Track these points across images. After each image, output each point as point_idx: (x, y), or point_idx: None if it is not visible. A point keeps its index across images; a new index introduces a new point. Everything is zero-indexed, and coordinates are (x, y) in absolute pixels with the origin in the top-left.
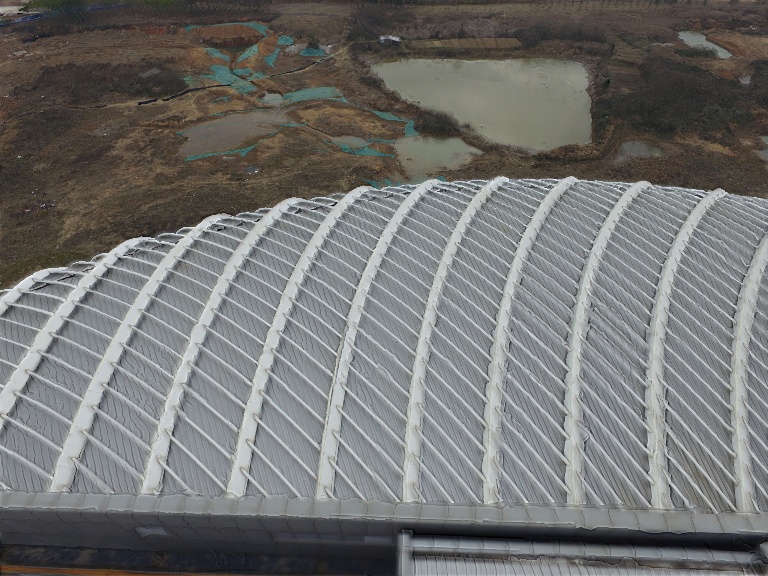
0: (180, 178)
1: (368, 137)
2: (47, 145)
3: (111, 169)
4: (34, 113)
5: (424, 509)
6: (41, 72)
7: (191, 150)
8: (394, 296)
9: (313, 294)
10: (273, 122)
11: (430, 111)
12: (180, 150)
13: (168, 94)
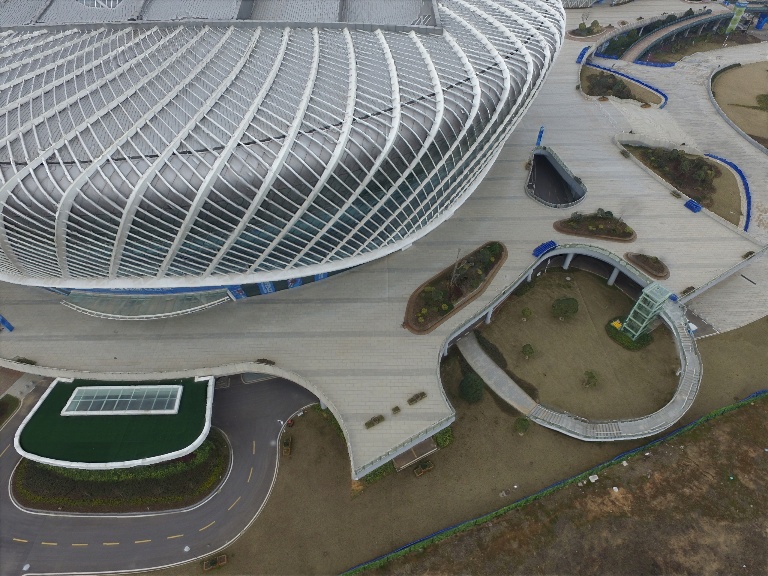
0: None
1: None
2: None
3: None
4: None
5: (227, 20)
6: None
7: None
8: (218, 70)
9: (260, 71)
10: None
11: None
12: None
13: None
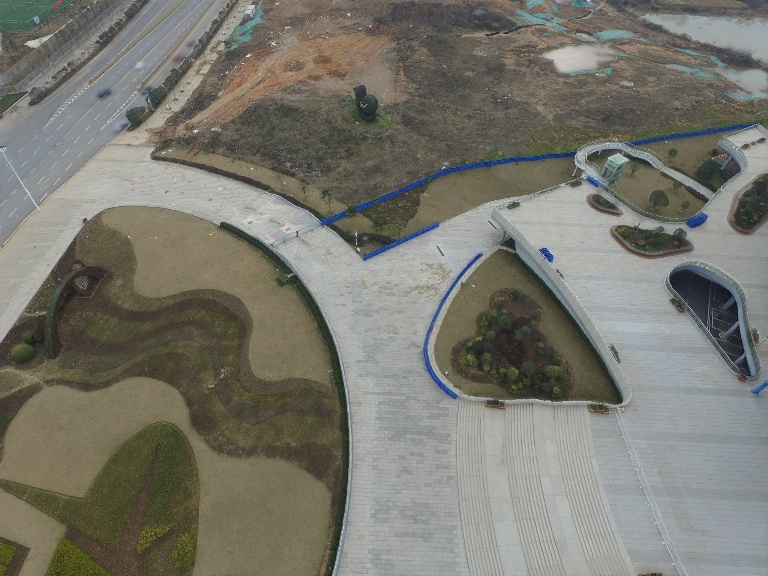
0: (584, 85)
1: (692, 65)
2: (452, 60)
3: (523, 78)
4: (421, 37)
5: None
6: (392, 7)
7: (565, 68)
8: None
9: None
10: (606, 52)
11: (729, 48)
12: (557, 68)
13: (506, 29)
